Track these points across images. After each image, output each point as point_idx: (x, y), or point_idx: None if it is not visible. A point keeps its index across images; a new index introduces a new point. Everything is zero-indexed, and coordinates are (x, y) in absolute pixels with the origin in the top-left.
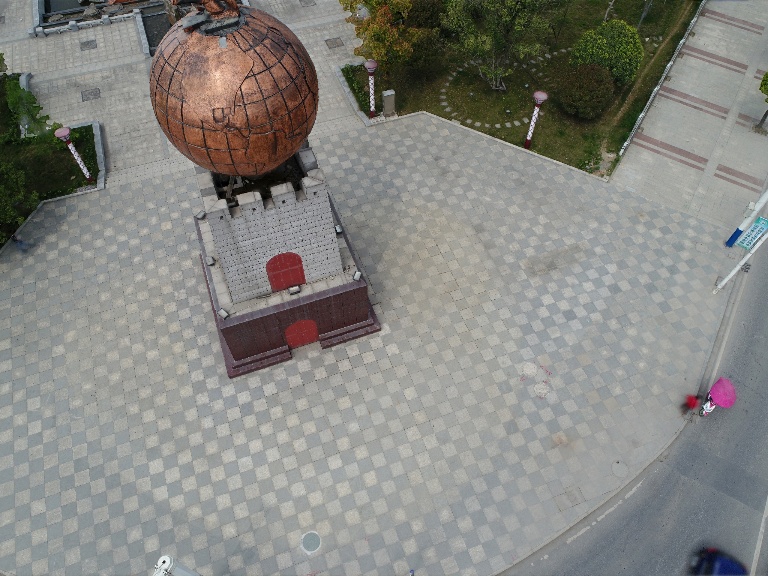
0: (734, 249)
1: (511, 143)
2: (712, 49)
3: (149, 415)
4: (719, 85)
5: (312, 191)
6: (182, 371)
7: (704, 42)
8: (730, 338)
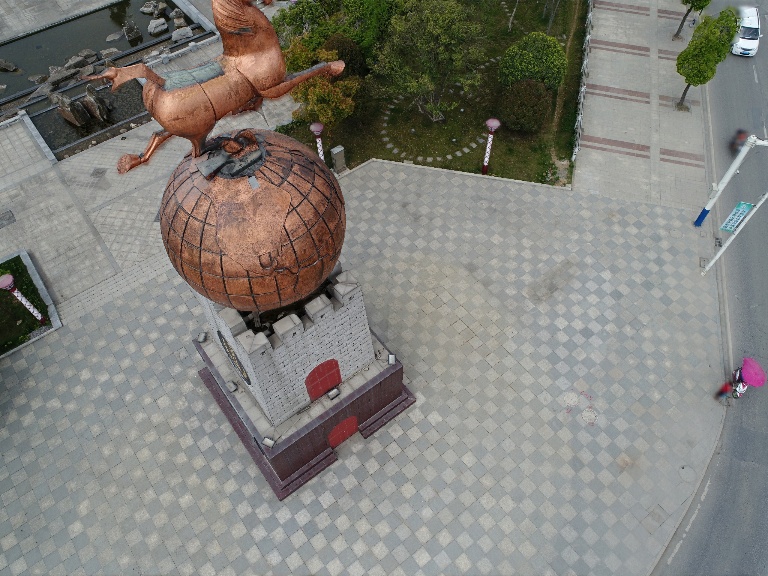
0: (703, 227)
1: (469, 172)
2: (613, 38)
3: (207, 571)
4: (632, 72)
5: (348, 297)
6: (225, 509)
7: (604, 33)
8: (731, 314)
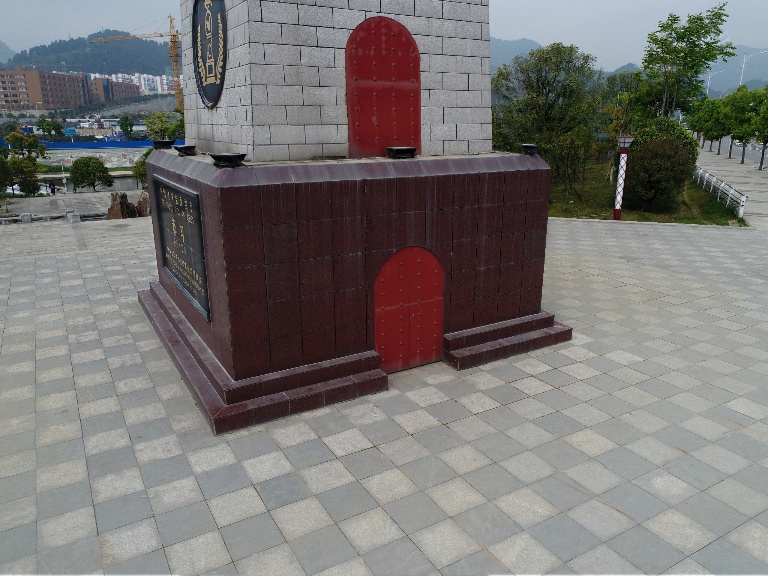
0: None
1: None
2: None
3: None
4: None
5: None
6: (57, 436)
7: None
8: None
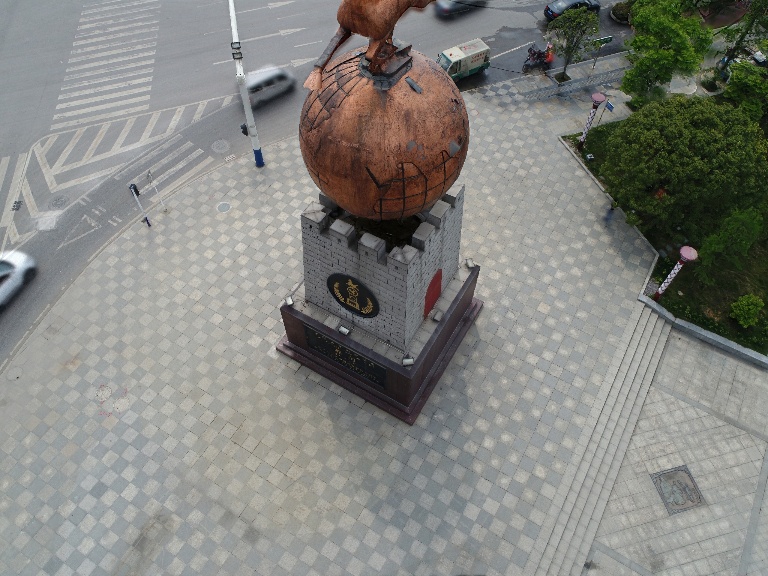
0: None
1: None
2: None
3: None
4: None
5: None
6: None
7: None
8: None
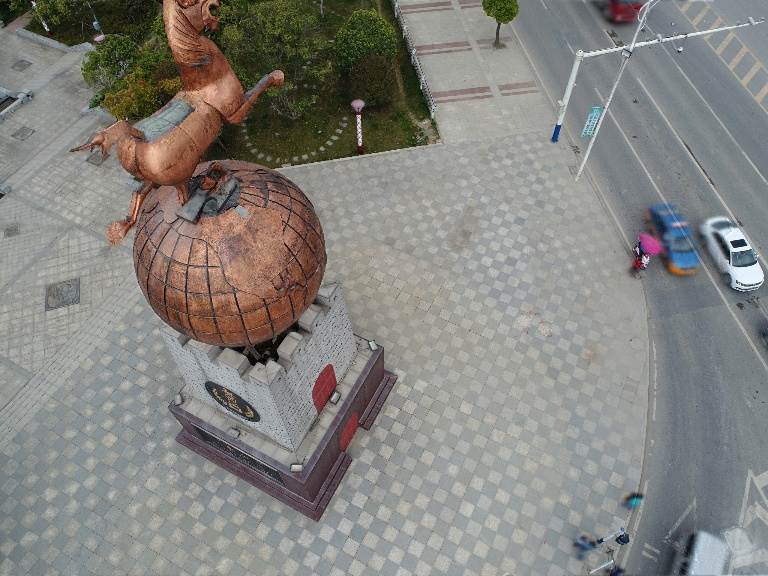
0: (560, 141)
1: (347, 157)
2: (417, 1)
3: None
4: (445, 26)
5: (332, 298)
6: (268, 554)
7: None
8: (611, 205)
